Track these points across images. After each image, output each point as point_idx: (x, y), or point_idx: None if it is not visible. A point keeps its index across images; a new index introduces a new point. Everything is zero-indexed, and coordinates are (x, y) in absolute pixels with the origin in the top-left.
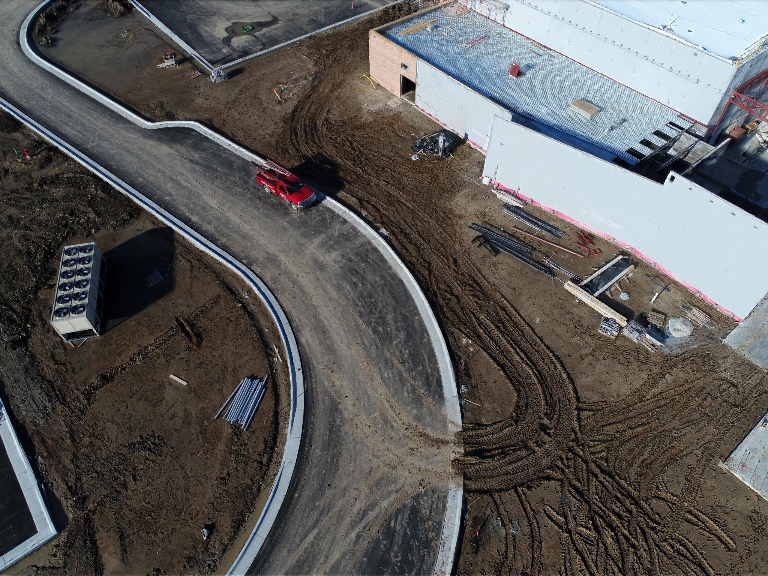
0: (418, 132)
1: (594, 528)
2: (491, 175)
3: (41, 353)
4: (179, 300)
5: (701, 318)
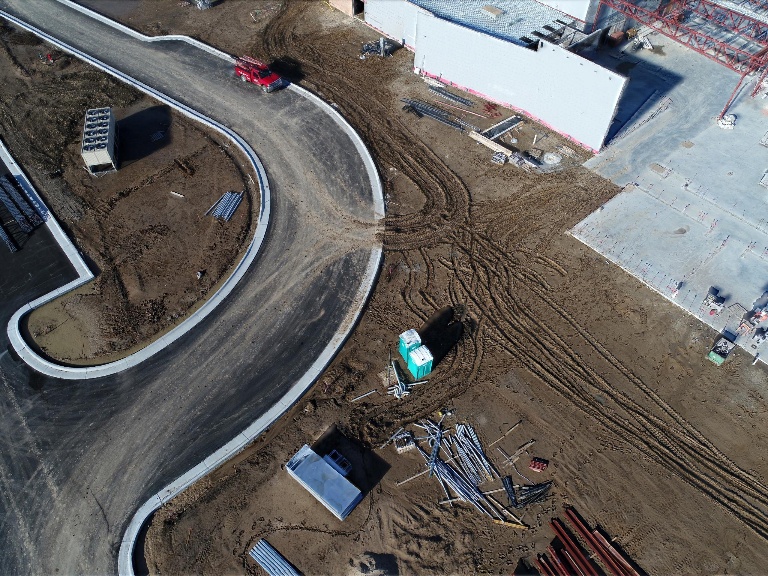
0: (366, 41)
1: (472, 267)
2: (420, 66)
3: (73, 181)
4: (176, 149)
5: (568, 152)
